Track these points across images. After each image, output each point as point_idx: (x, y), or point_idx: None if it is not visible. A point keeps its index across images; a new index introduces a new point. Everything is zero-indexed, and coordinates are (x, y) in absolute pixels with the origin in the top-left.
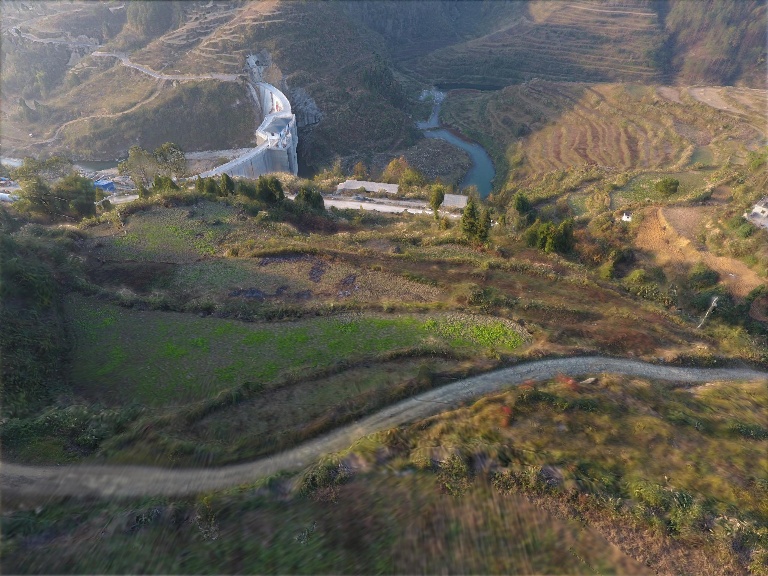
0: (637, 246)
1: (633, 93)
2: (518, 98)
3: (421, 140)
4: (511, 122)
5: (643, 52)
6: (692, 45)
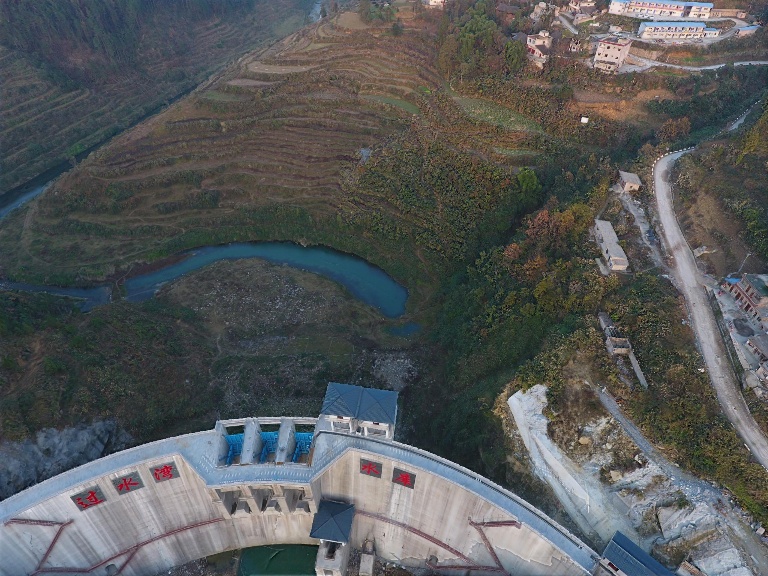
0: (623, 122)
1: (228, 99)
2: (129, 182)
3: (173, 303)
4: (178, 204)
5: (45, 79)
6: (63, 52)
